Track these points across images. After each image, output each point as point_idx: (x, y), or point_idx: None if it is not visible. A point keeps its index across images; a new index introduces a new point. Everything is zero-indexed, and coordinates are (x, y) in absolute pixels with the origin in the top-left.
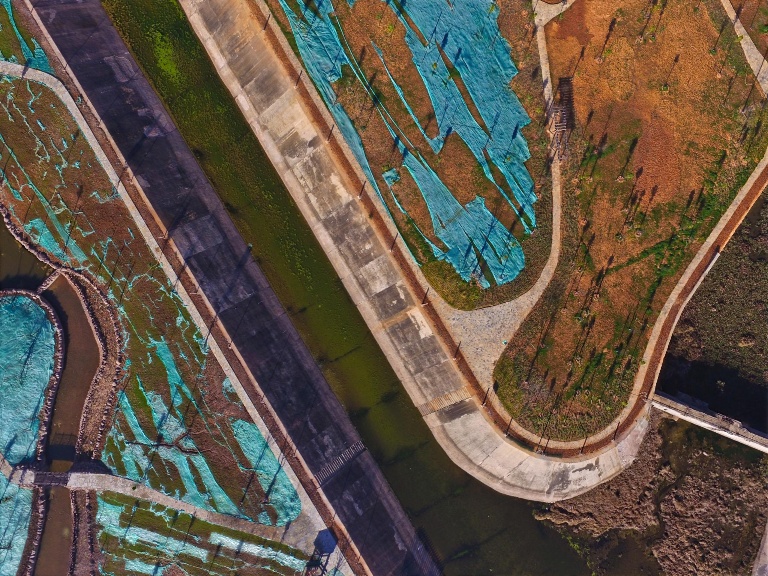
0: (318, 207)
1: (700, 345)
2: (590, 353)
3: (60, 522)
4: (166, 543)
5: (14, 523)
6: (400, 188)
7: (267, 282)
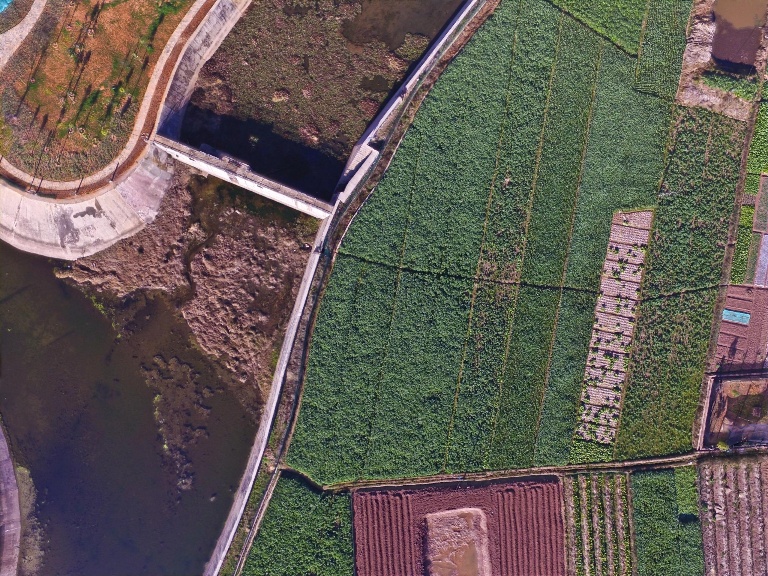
0: None
1: (231, 99)
2: (85, 90)
3: None
4: None
5: None
6: None
7: None
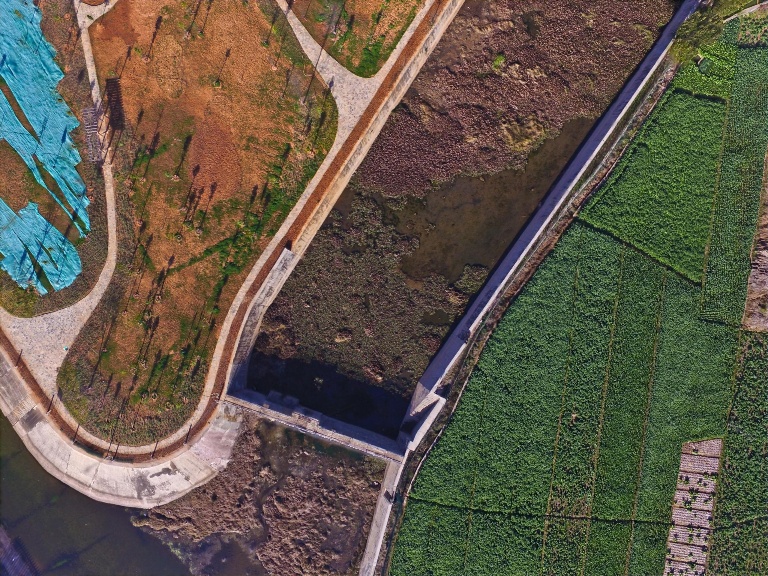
0: None
1: (294, 342)
2: (155, 356)
3: None
4: None
5: None
6: None
7: None
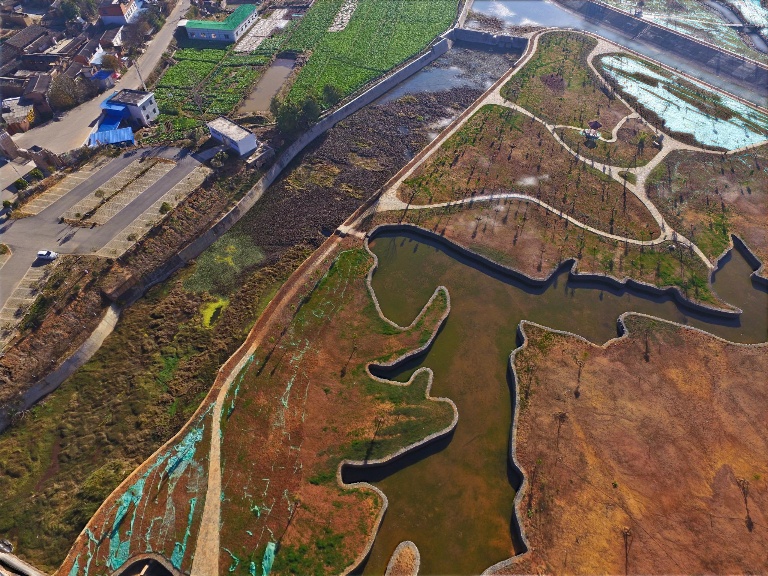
0: None
1: None
2: None
3: None
4: (696, 16)
5: None
6: None
7: None
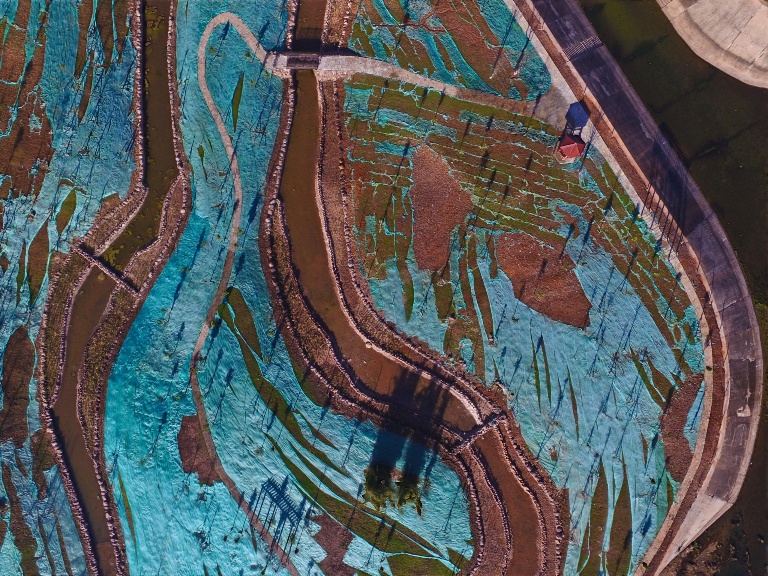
0: None
1: None
2: None
3: (307, 115)
4: (415, 123)
5: (268, 109)
6: None
7: None
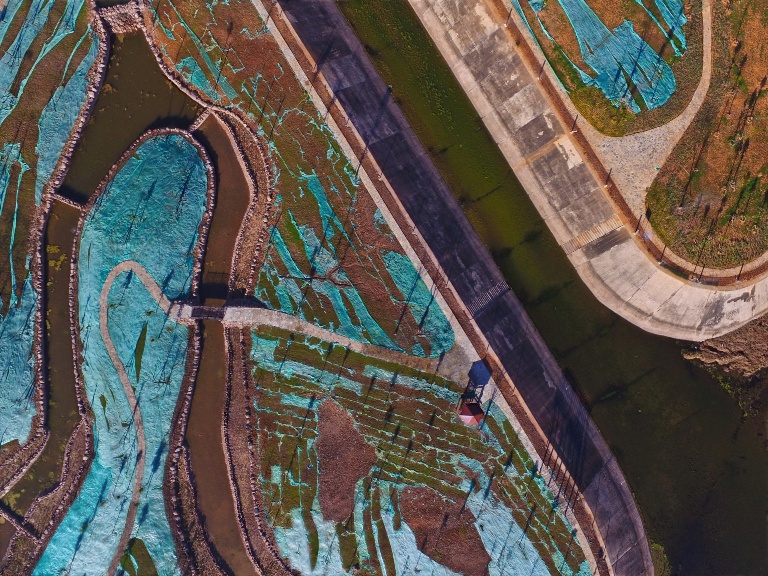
0: (459, 43)
1: None
2: (744, 178)
3: (214, 360)
4: (321, 376)
5: (172, 358)
6: (547, 14)
7: (408, 123)
